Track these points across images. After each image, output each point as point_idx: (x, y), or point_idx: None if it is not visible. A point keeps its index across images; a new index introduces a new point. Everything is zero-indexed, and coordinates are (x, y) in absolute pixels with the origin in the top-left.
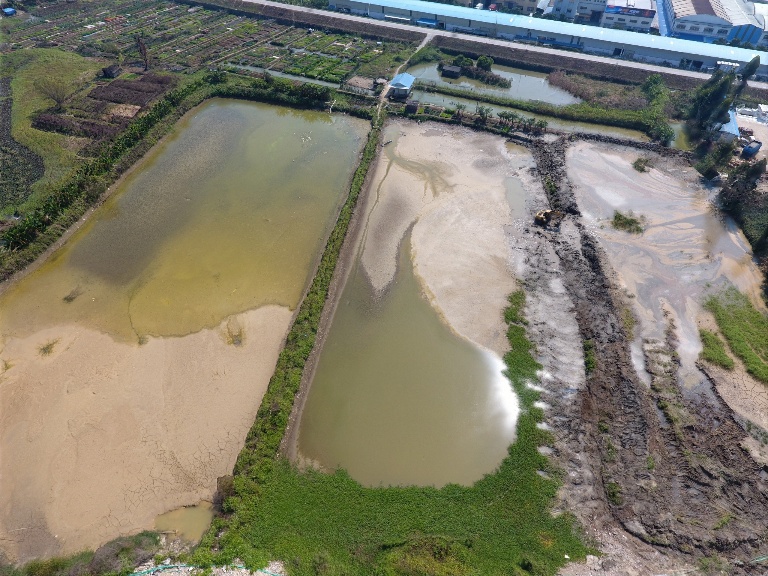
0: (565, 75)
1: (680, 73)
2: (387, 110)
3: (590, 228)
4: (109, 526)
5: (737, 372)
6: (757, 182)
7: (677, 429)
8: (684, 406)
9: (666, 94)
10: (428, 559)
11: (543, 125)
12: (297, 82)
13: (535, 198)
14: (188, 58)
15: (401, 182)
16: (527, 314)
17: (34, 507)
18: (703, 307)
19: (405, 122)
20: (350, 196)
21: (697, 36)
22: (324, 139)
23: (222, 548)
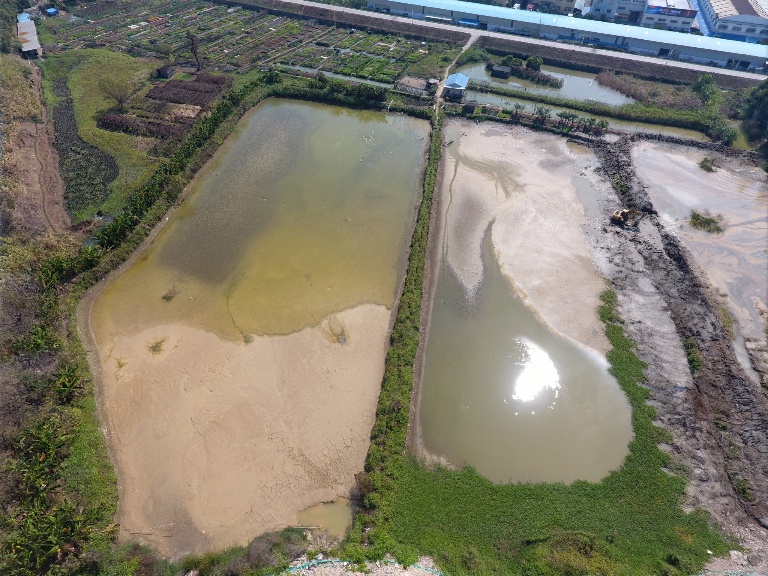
0: (614, 75)
1: (730, 73)
2: (445, 110)
3: (669, 228)
4: (253, 522)
5: None
6: None
7: None
8: None
9: (720, 94)
10: (576, 554)
11: (604, 125)
12: (350, 82)
13: (607, 198)
14: (237, 58)
15: (471, 182)
16: (621, 313)
17: (176, 503)
18: None
19: (463, 122)
20: (425, 196)
21: (739, 36)
22: (387, 139)
23: (372, 543)
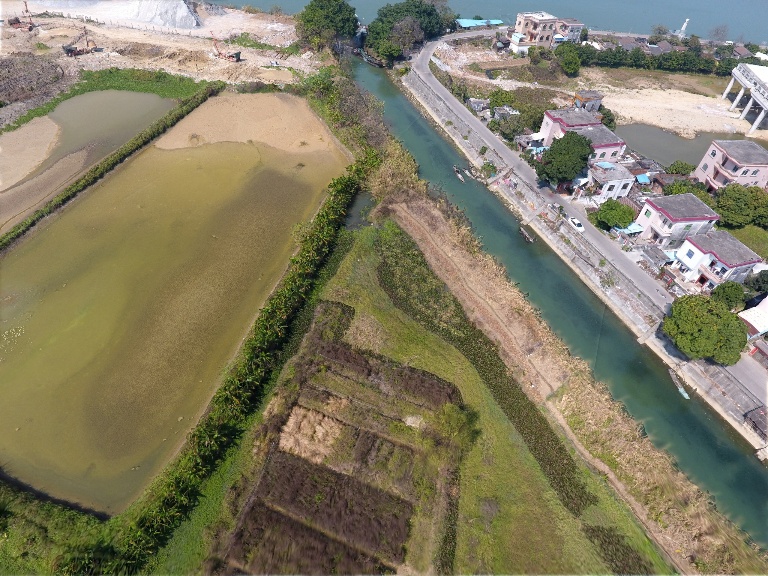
0: None
1: None
2: None
3: None
4: None
5: None
6: None
7: None
8: None
9: None
10: None
11: None
12: None
13: None
14: None
15: None
16: None
17: None
18: None
19: None
20: (39, 214)
21: None
22: None
23: None
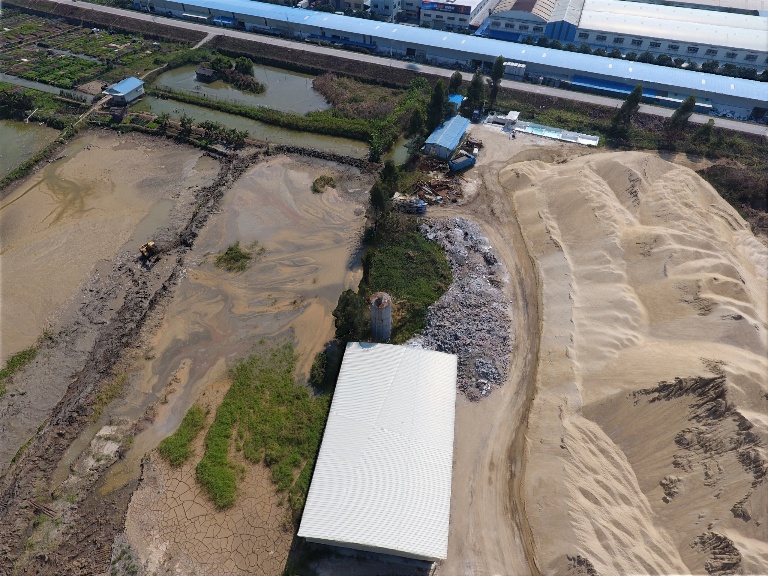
0: (335, 78)
1: None
2: (89, 120)
3: (187, 265)
4: None
5: (183, 469)
6: (437, 205)
7: (22, 560)
8: (64, 523)
9: (419, 100)
10: None
11: (240, 137)
12: (17, 88)
13: (172, 225)
14: None
15: (28, 206)
16: (14, 381)
17: None
18: (228, 372)
19: (105, 133)
20: None
21: (514, 34)
22: None
23: None
